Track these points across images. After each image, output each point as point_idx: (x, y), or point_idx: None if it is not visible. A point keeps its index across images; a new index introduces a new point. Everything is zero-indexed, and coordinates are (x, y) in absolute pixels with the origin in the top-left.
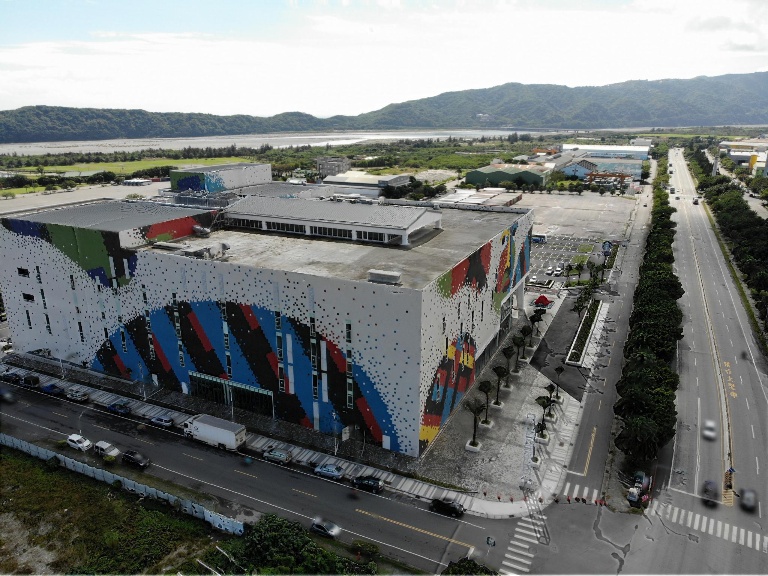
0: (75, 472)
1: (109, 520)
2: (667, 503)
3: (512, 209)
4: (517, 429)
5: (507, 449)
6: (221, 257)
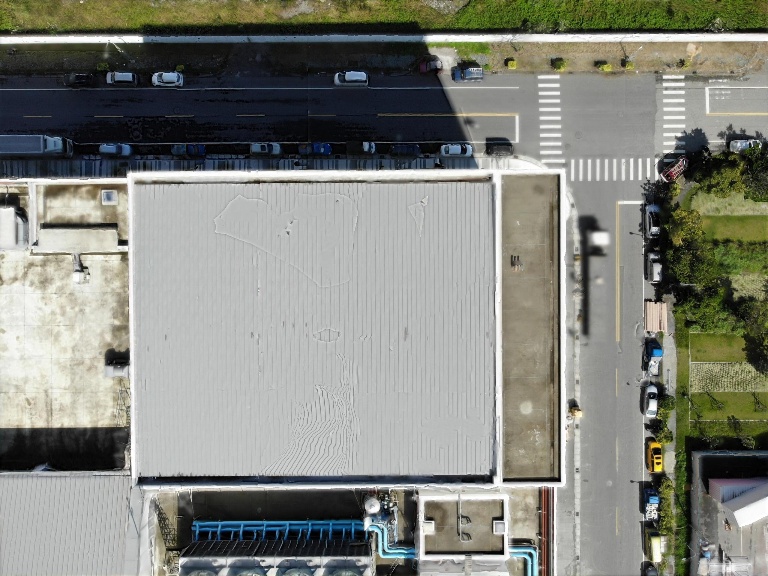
0: None
1: (25, 4)
2: None
3: None
4: None
5: None
6: None
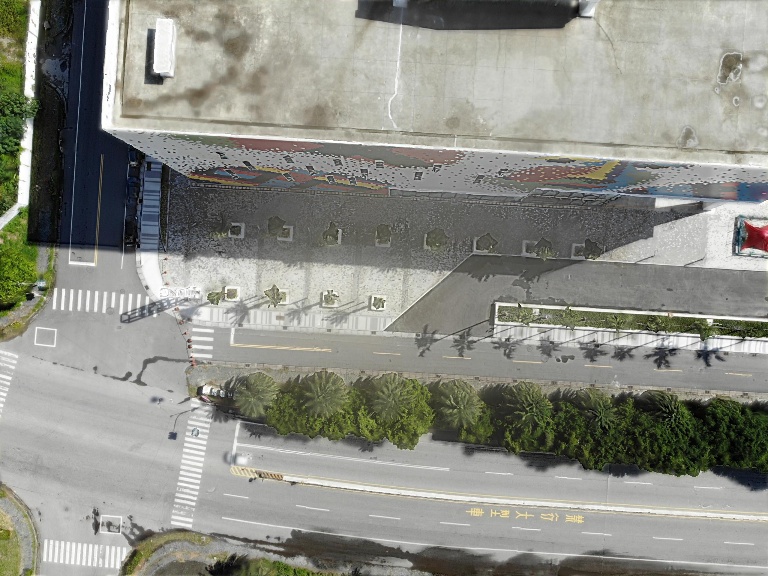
0: None
1: None
2: (213, 418)
3: None
4: (290, 268)
5: (246, 264)
6: None
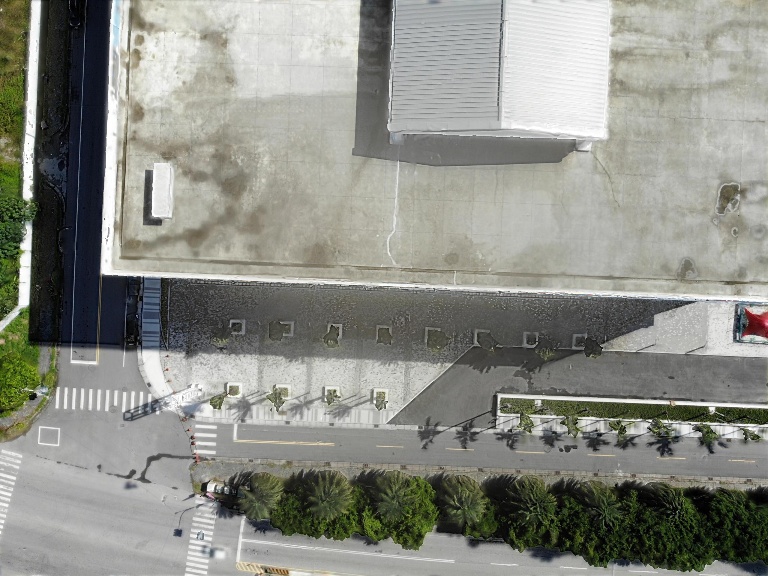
0: None
1: None
2: (218, 514)
3: None
4: (292, 363)
5: (247, 361)
6: None
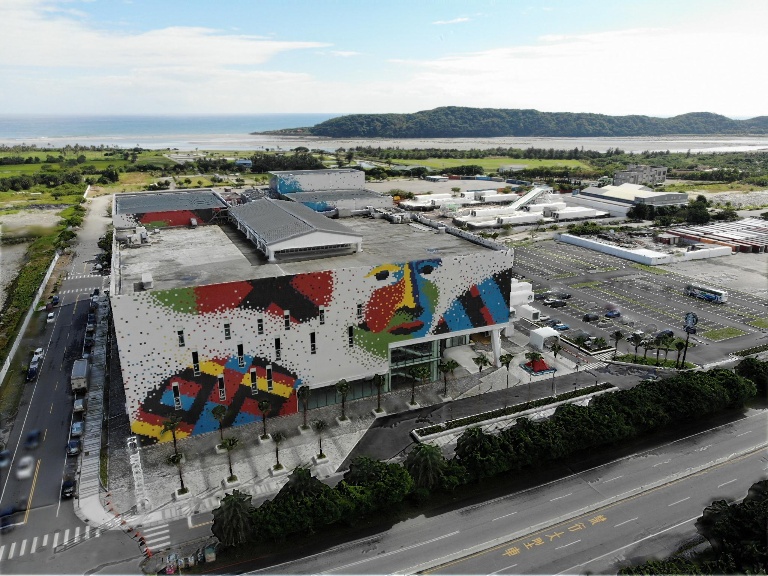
0: (5, 369)
1: None
2: None
3: (497, 245)
4: (234, 464)
5: (191, 474)
6: (139, 244)
